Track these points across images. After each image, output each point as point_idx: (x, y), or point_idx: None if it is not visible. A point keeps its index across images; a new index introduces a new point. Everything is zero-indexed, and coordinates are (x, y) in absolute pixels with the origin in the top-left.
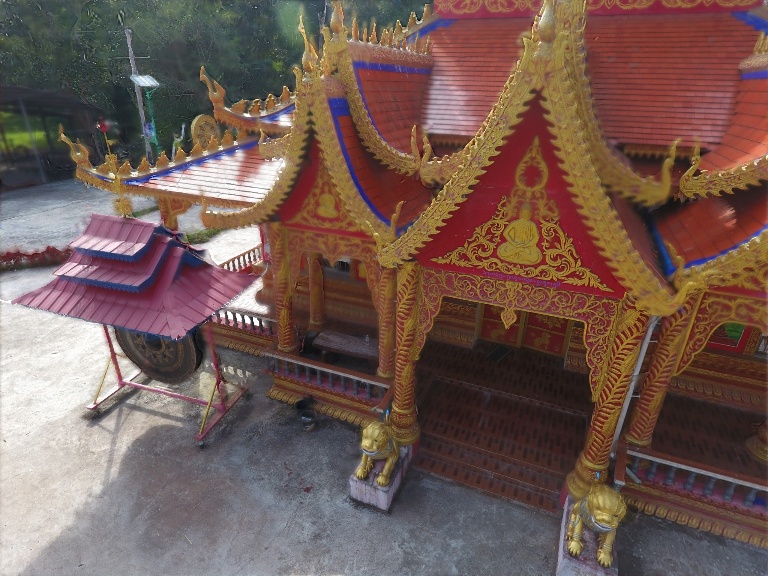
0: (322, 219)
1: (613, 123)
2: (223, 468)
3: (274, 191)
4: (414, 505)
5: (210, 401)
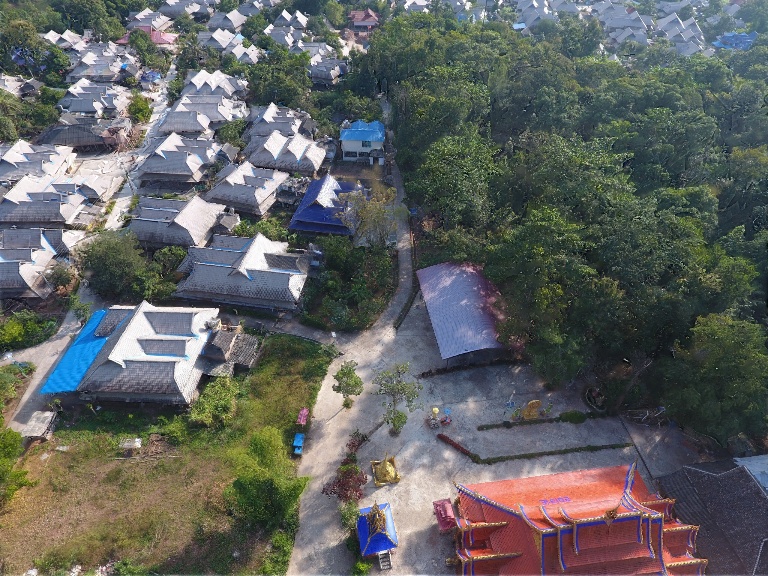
0: None
1: (503, 568)
2: (439, 540)
3: None
4: (450, 569)
5: None
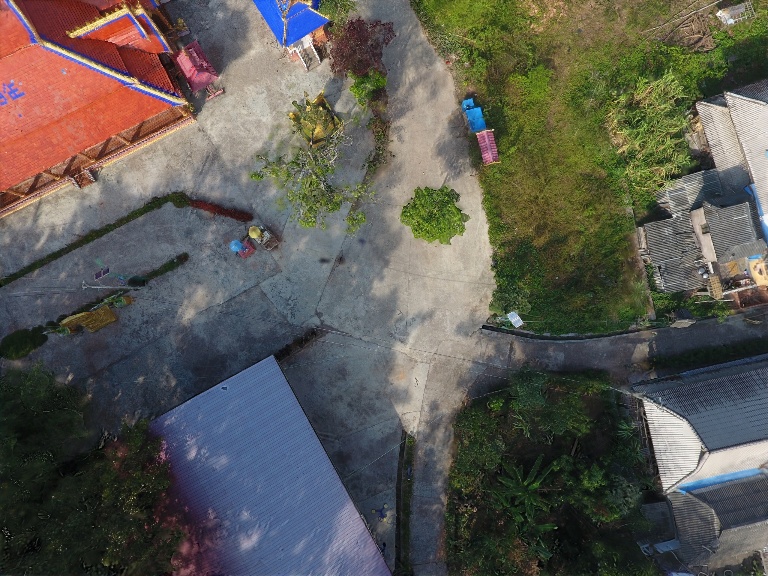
0: None
1: None
2: None
3: None
4: None
5: None
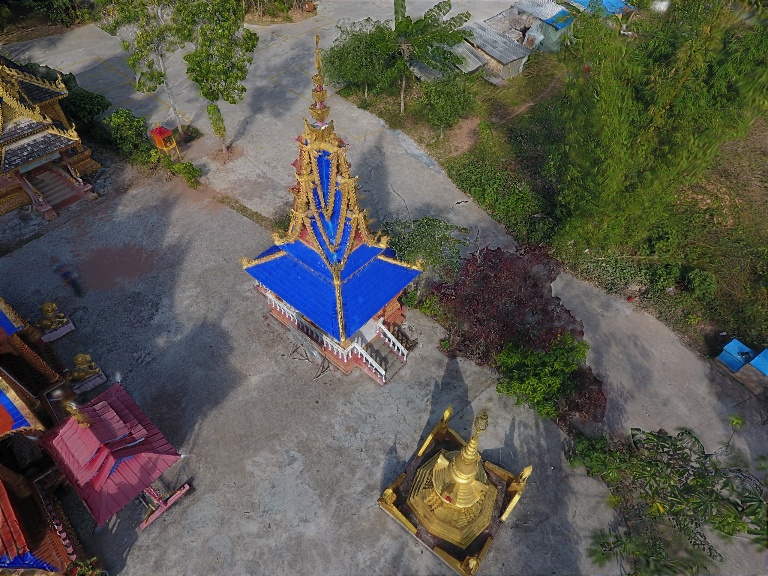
0: None
1: None
2: None
3: (4, 380)
4: None
5: None
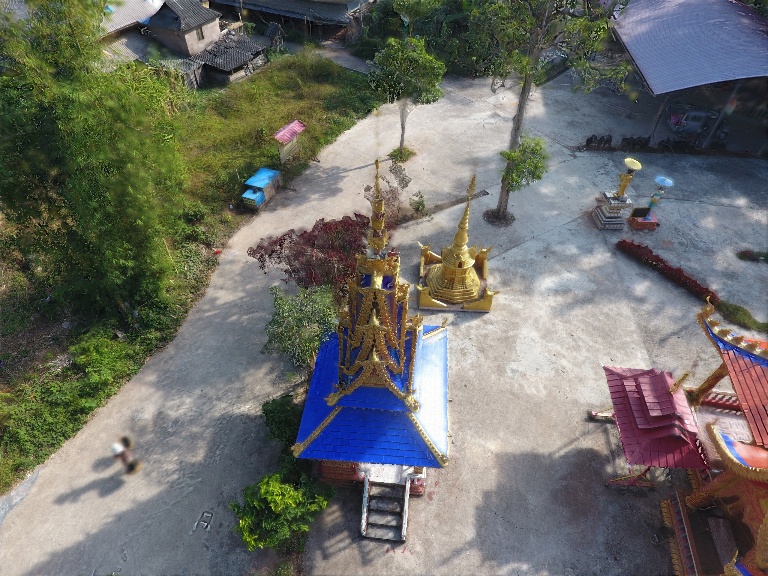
0: (759, 504)
1: None
2: (602, 504)
3: (743, 468)
4: None
5: (628, 477)
